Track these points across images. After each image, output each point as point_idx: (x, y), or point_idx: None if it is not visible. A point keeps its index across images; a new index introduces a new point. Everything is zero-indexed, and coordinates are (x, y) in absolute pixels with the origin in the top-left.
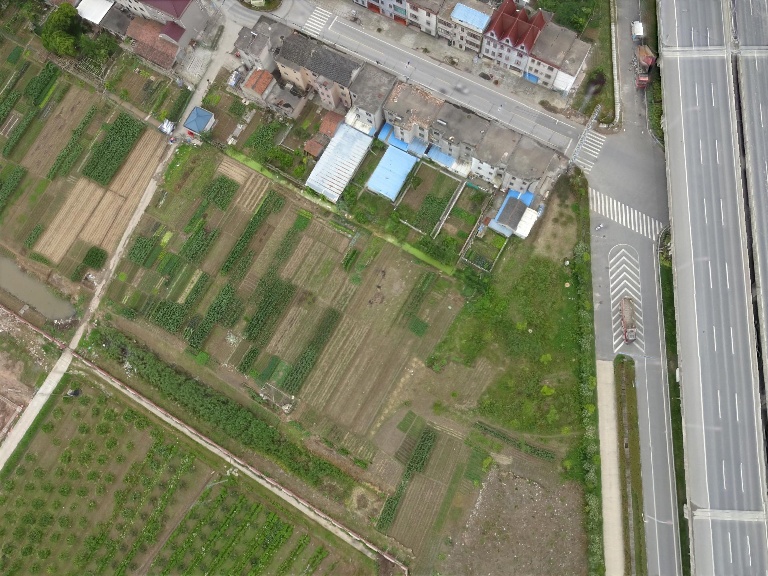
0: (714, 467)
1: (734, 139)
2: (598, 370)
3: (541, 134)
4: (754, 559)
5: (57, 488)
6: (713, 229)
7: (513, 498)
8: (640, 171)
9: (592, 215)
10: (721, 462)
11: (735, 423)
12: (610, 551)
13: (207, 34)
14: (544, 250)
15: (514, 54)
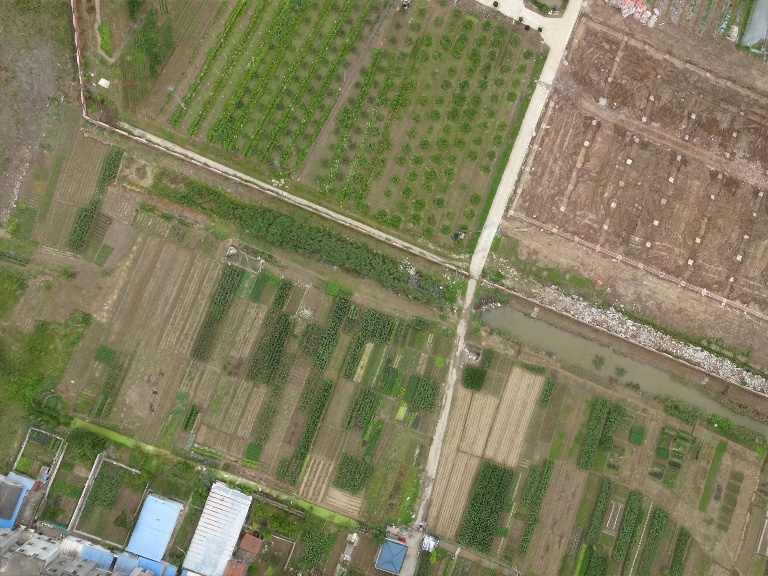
0: None
1: None
2: None
3: None
4: None
5: (451, 144)
6: None
7: None
8: None
9: None
10: None
11: None
12: None
13: None
14: None
15: None
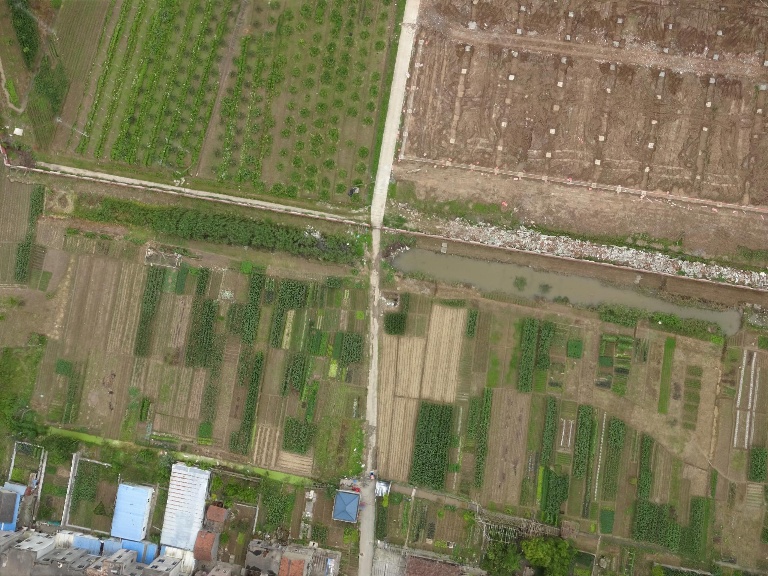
0: None
1: None
2: None
3: None
4: None
5: (330, 106)
6: None
7: None
8: None
9: None
10: None
11: None
12: None
13: None
14: None
15: None
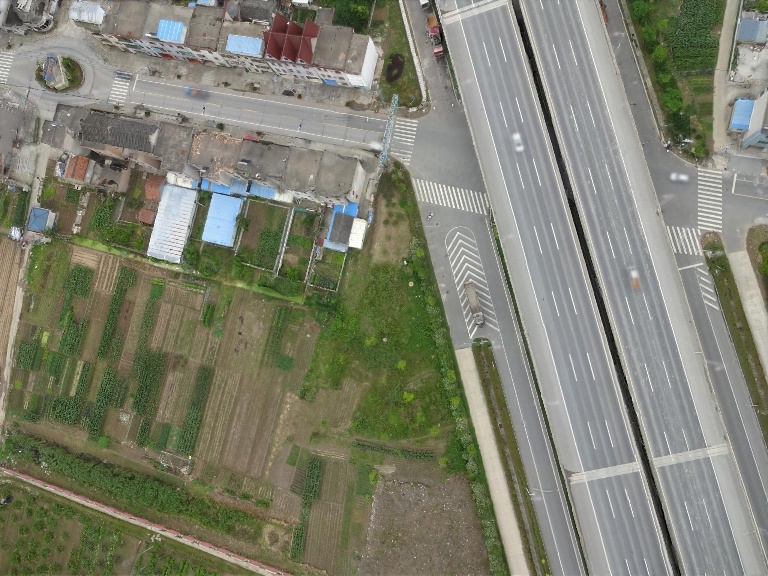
0: (580, 430)
1: (533, 91)
2: (459, 360)
3: (355, 137)
4: (636, 509)
5: None
6: (531, 192)
7: (401, 504)
8: (458, 147)
9: (421, 206)
10: (586, 424)
11: (592, 382)
12: (505, 530)
13: (27, 131)
14: (382, 255)
15: (300, 67)
